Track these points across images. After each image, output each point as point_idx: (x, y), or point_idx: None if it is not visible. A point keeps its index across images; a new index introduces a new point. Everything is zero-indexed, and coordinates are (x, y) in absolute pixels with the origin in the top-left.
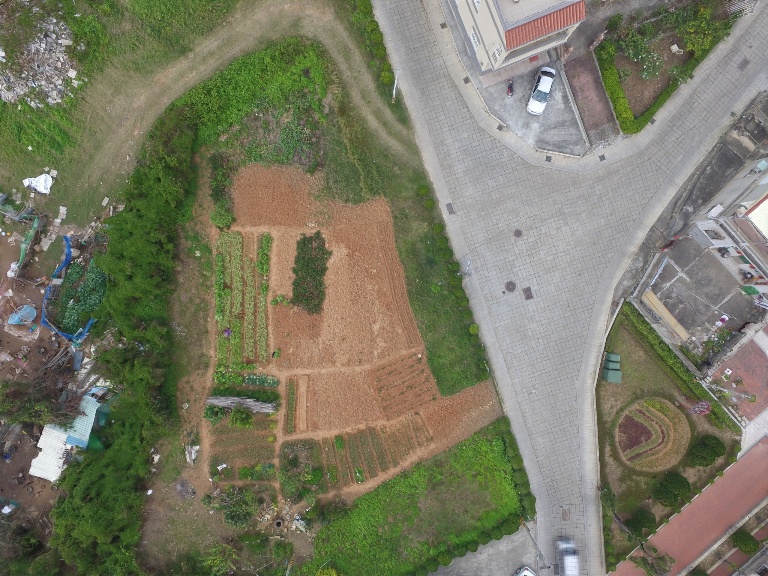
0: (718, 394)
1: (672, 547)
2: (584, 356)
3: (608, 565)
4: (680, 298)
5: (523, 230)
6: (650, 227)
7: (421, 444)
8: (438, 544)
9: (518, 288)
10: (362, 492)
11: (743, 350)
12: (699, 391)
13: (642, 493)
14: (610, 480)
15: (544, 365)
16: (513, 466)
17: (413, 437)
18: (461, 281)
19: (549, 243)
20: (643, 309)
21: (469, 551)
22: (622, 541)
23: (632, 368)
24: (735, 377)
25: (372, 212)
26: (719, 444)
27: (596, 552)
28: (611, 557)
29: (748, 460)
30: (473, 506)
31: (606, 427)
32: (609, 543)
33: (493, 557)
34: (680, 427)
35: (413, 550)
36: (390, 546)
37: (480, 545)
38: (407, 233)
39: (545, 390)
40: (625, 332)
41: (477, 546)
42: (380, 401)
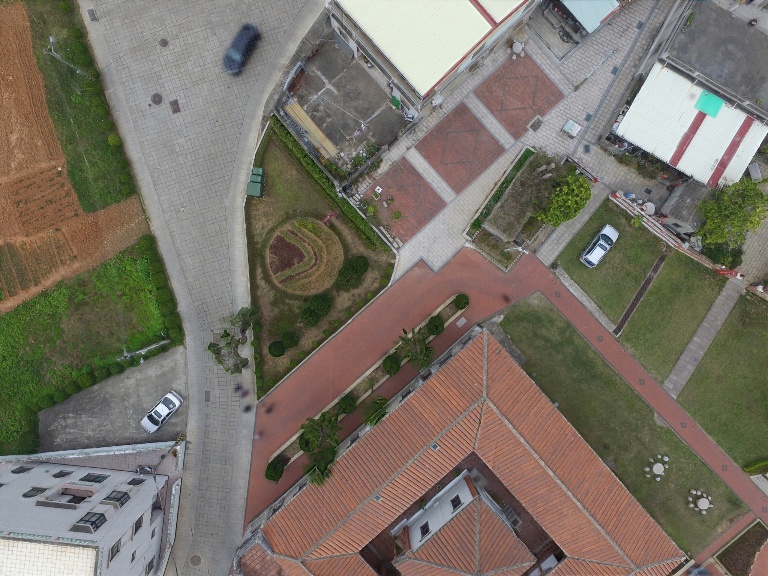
0: (369, 213)
1: (326, 374)
2: (234, 173)
3: (257, 390)
4: (328, 111)
5: (169, 39)
6: (301, 39)
7: (64, 262)
8: (82, 367)
9: (165, 101)
10: (2, 311)
11: (394, 168)
12: (345, 208)
13: (294, 317)
14: (262, 303)
15: (192, 182)
16: (153, 283)
17: (55, 255)
18: (97, 88)
19: (196, 54)
20: (279, 117)
21: (116, 375)
22: (275, 367)
23: (284, 187)
24: (386, 196)
25: (7, 15)
26: (357, 259)
27: (248, 379)
28: (257, 380)
29: (404, 285)
30: (118, 328)
31: (257, 248)
32: (257, 367)
33: (141, 382)
34: (333, 249)
35: (56, 373)
36: (31, 368)
37: (127, 369)
38: (45, 39)
39: (194, 208)
40: (277, 149)
41: (119, 368)
42: (18, 215)
